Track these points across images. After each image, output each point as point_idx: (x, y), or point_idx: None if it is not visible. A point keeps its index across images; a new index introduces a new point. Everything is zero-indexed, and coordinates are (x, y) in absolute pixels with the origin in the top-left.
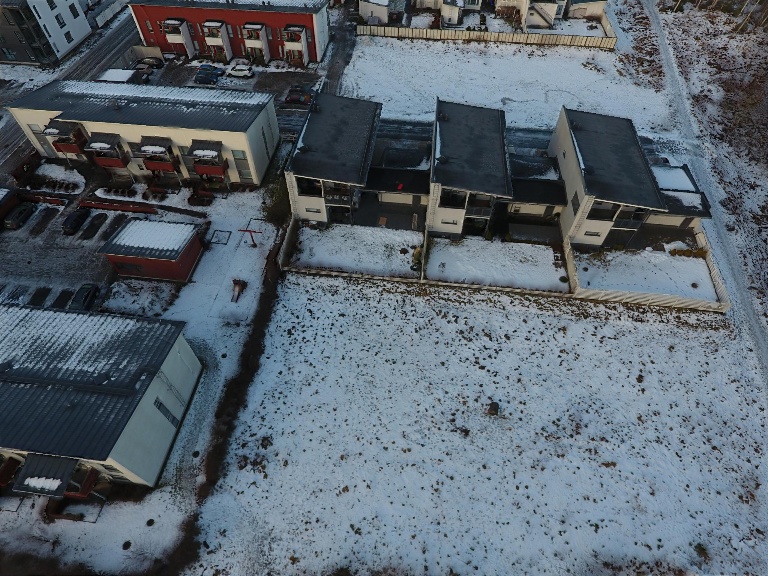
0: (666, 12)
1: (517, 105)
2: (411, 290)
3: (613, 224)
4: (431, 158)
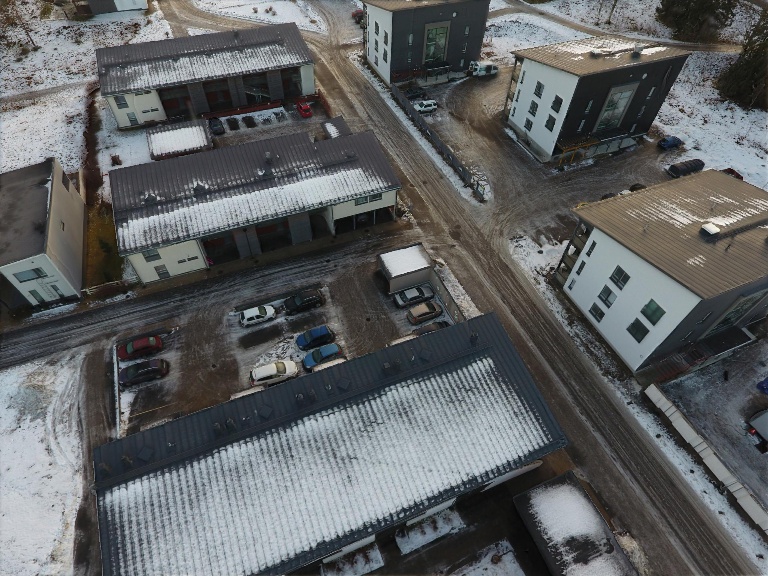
0: None
1: None
2: None
3: None
4: None
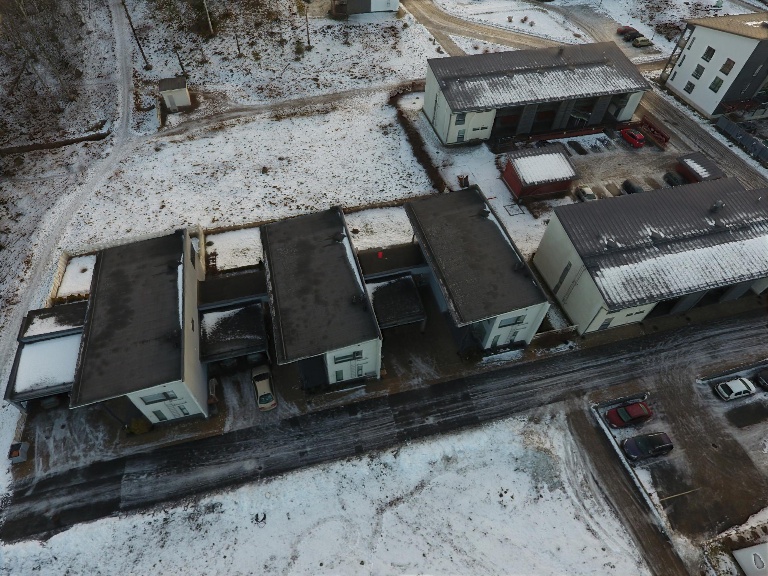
0: None
1: None
2: None
3: None
4: None
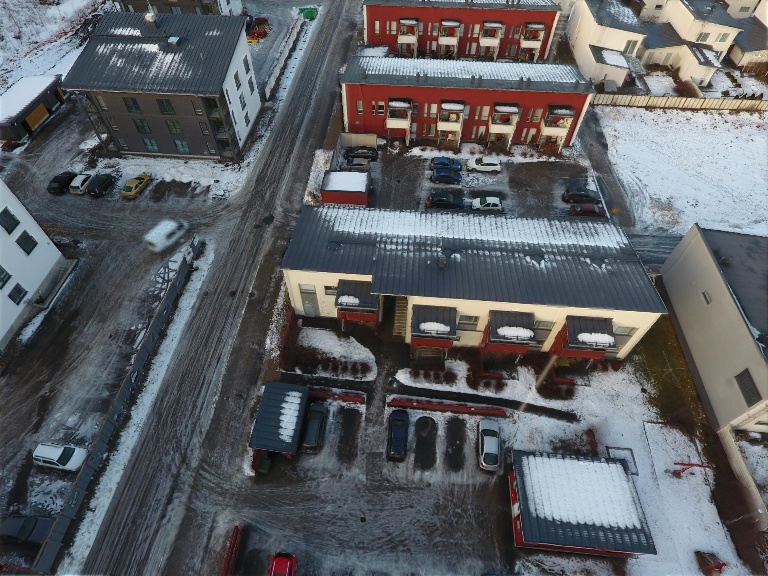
0: None
1: None
2: None
3: None
4: None
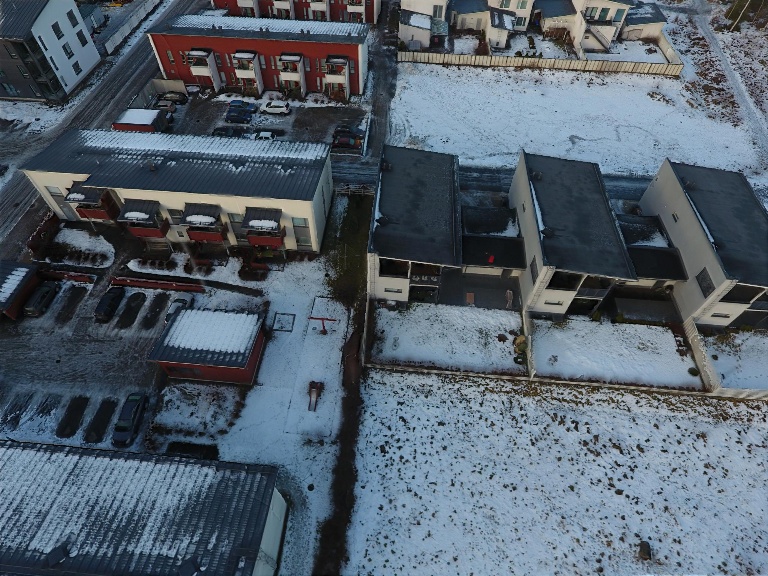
0: (722, 32)
1: (588, 144)
2: (518, 389)
3: (749, 306)
4: (520, 221)
